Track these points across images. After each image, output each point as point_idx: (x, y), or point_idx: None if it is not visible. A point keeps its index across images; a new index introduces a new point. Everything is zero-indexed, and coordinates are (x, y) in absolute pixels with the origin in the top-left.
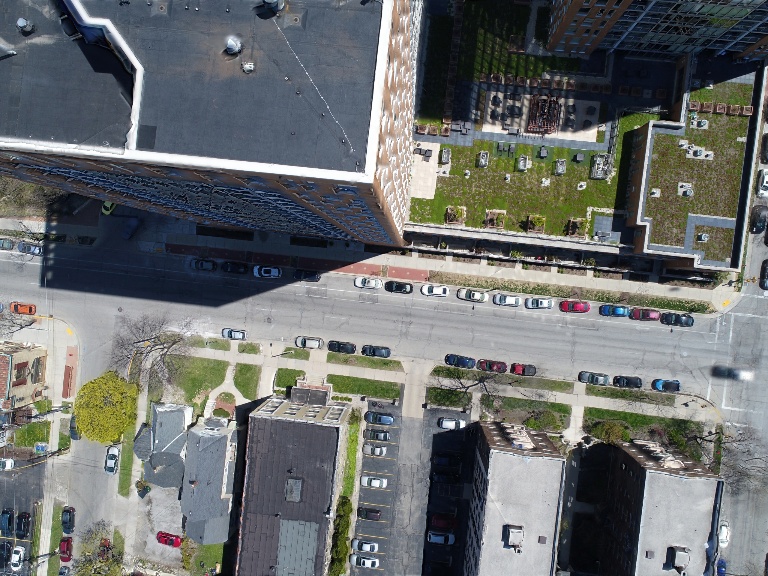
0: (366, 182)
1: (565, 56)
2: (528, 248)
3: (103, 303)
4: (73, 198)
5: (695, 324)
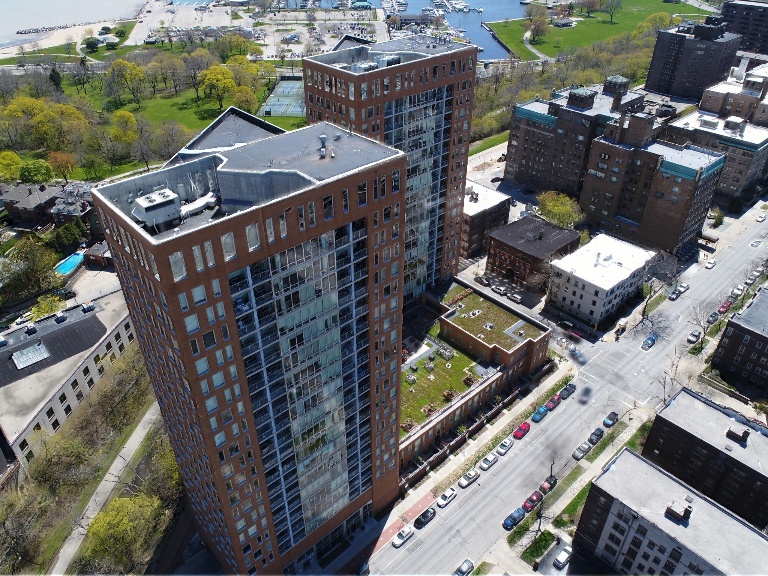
0: None
1: None
2: None
3: None
4: None
5: (576, 387)
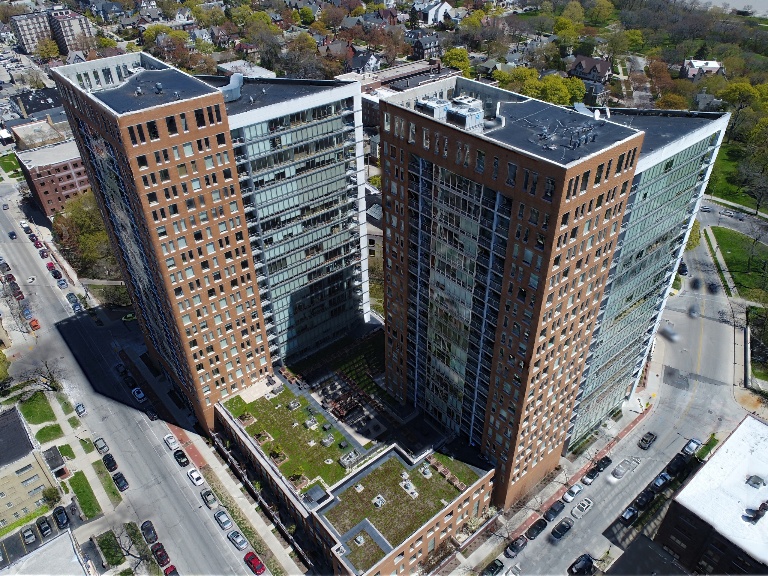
0: (117, 115)
1: (392, 396)
2: (271, 495)
3: (62, 349)
4: (122, 307)
5: None
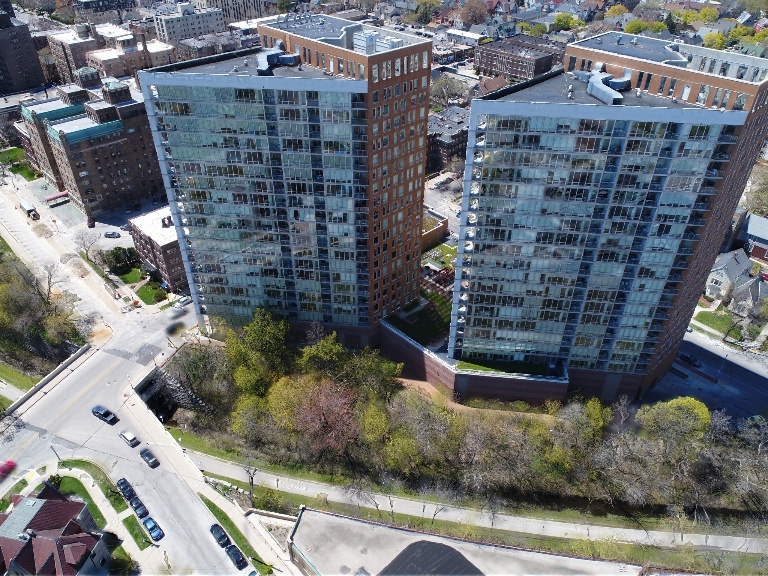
0: None
1: None
2: None
3: None
4: None
5: None
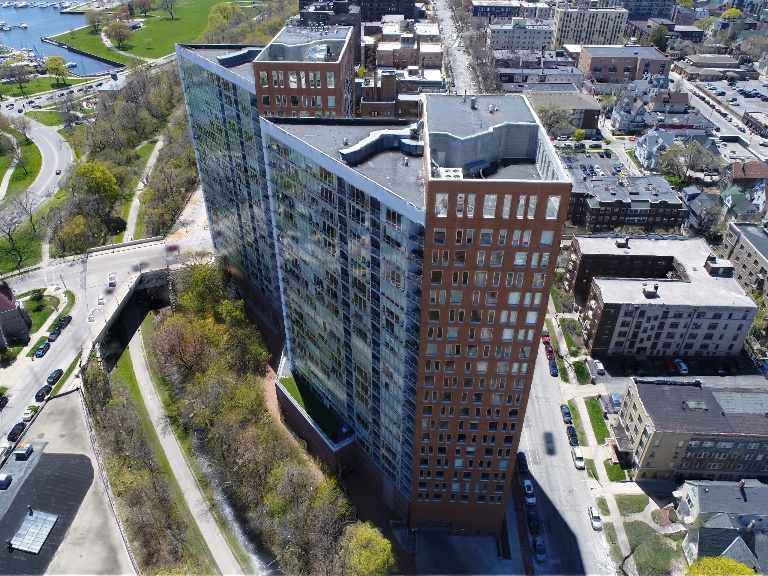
0: None
1: None
2: None
3: None
4: None
5: None
